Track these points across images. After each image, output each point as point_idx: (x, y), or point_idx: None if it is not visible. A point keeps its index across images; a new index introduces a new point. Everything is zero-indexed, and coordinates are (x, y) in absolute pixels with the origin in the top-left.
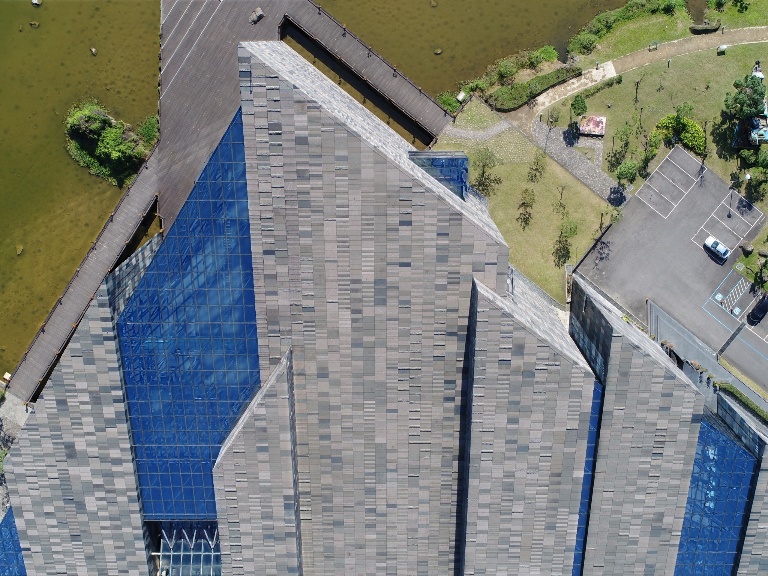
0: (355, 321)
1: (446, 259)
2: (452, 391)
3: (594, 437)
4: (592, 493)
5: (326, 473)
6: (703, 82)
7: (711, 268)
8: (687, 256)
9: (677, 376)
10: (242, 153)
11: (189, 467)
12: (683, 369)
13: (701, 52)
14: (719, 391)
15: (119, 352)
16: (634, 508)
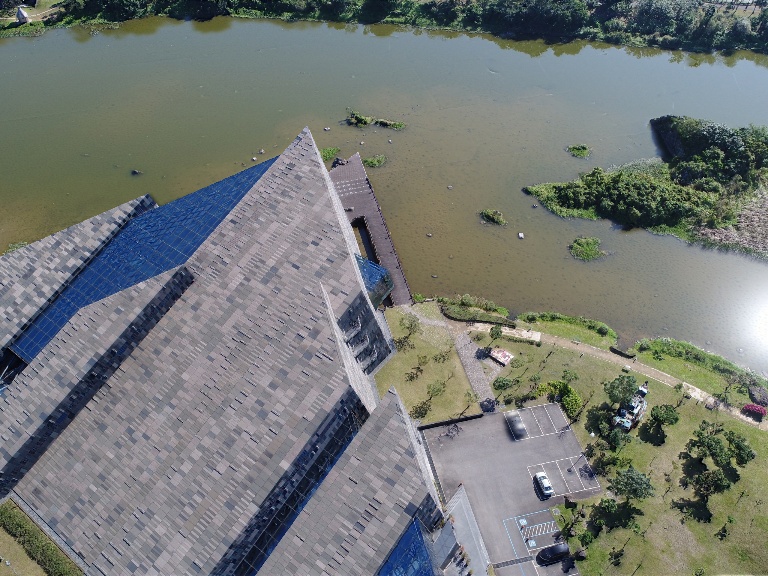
0: (242, 285)
1: (321, 276)
2: None
3: None
4: (287, 530)
5: (133, 380)
6: (601, 378)
7: (530, 496)
8: (516, 475)
9: (416, 456)
10: None
11: None
12: (445, 526)
13: (610, 362)
14: None
15: (113, 236)
16: (309, 574)
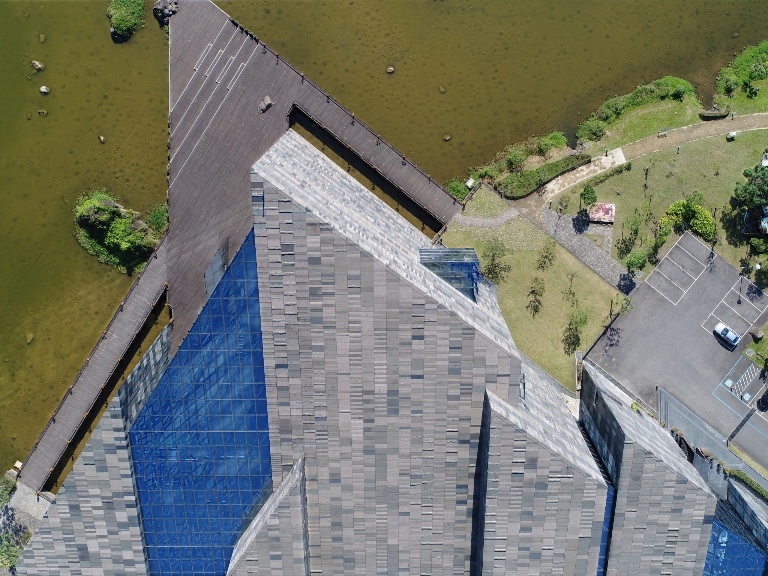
0: (367, 430)
1: (458, 371)
2: (464, 495)
3: (606, 536)
4: None
5: (338, 572)
6: (712, 168)
7: (721, 354)
8: (697, 342)
9: (689, 480)
10: (254, 271)
11: (201, 566)
12: (694, 460)
13: (710, 138)
14: (729, 477)
15: (132, 459)
16: None
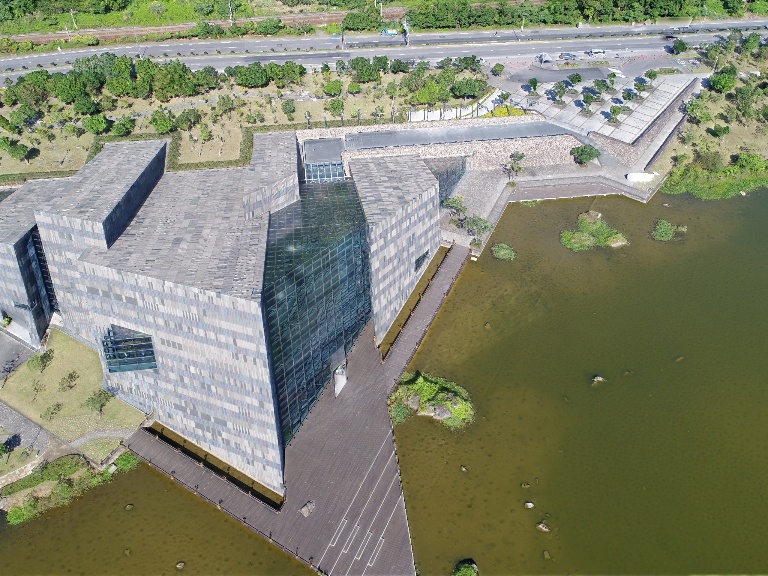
0: None
1: None
2: None
3: None
4: None
5: None
6: None
7: None
8: None
9: None
10: None
11: None
12: None
13: None
14: None
15: None
16: None
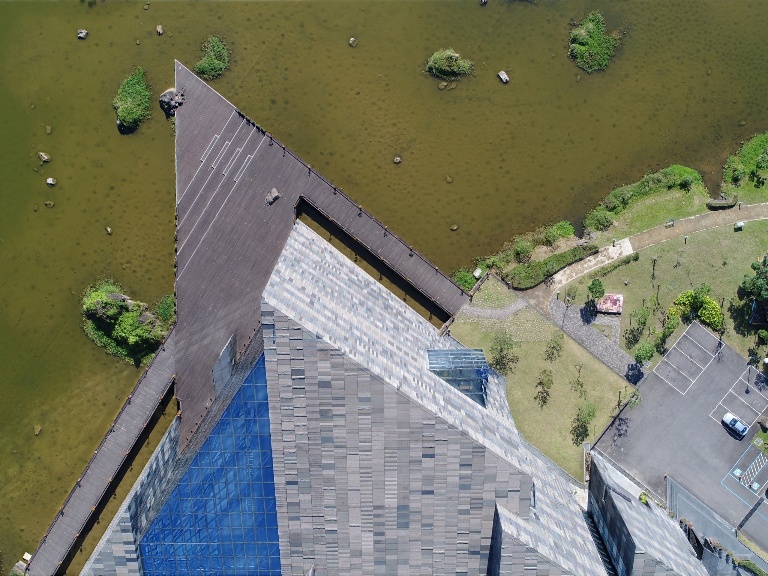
0: (378, 542)
1: (469, 487)
2: None
3: None
4: None
5: None
6: (720, 258)
7: (729, 443)
8: (705, 432)
9: None
10: (265, 392)
11: None
12: (703, 554)
13: (718, 228)
14: (738, 567)
15: (142, 569)
16: None
